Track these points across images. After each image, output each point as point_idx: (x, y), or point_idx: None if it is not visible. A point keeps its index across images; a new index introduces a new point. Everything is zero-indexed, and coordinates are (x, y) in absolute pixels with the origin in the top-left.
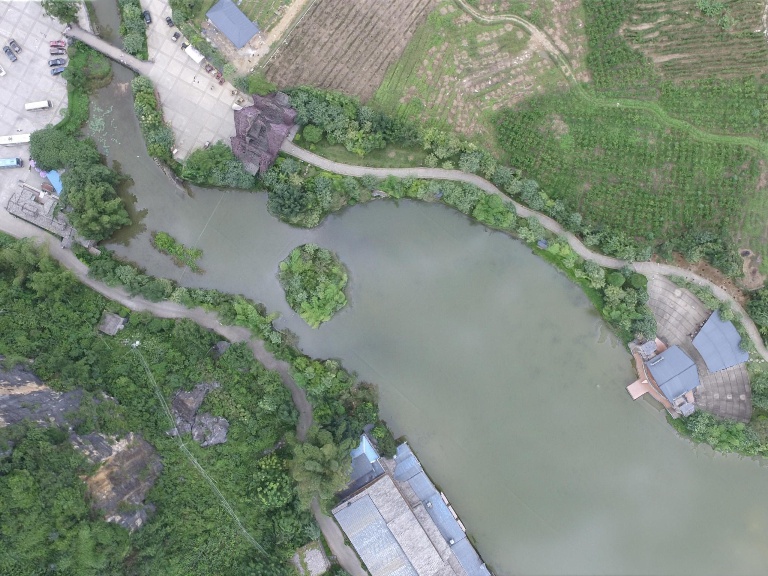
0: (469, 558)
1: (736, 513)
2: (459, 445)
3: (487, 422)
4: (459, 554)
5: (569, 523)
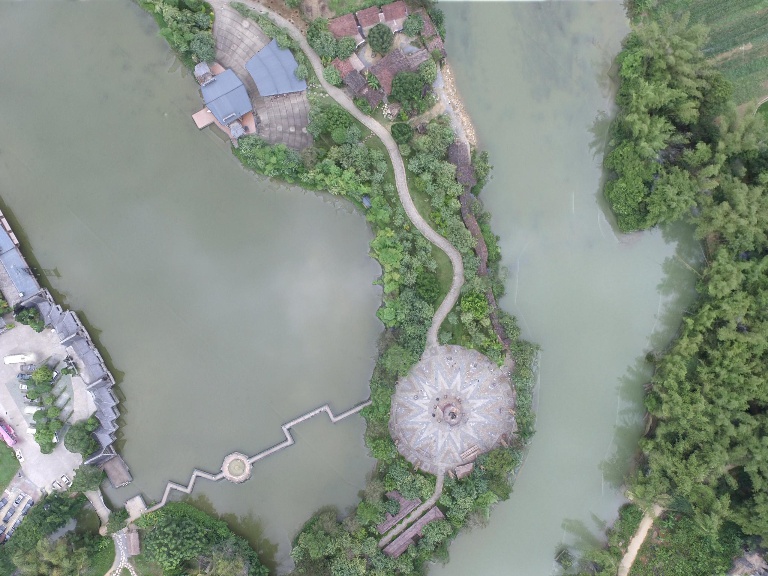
0: (18, 269)
1: (296, 246)
2: (26, 165)
3: (53, 144)
4: (8, 264)
5: (129, 247)
